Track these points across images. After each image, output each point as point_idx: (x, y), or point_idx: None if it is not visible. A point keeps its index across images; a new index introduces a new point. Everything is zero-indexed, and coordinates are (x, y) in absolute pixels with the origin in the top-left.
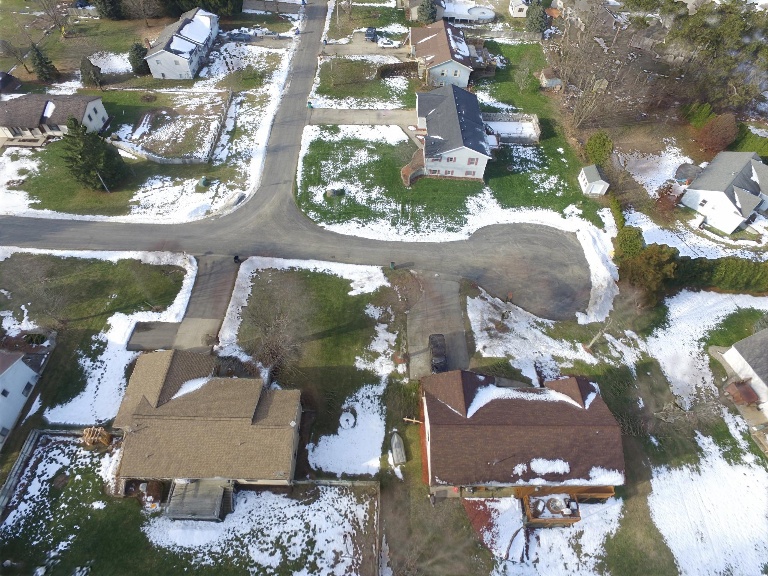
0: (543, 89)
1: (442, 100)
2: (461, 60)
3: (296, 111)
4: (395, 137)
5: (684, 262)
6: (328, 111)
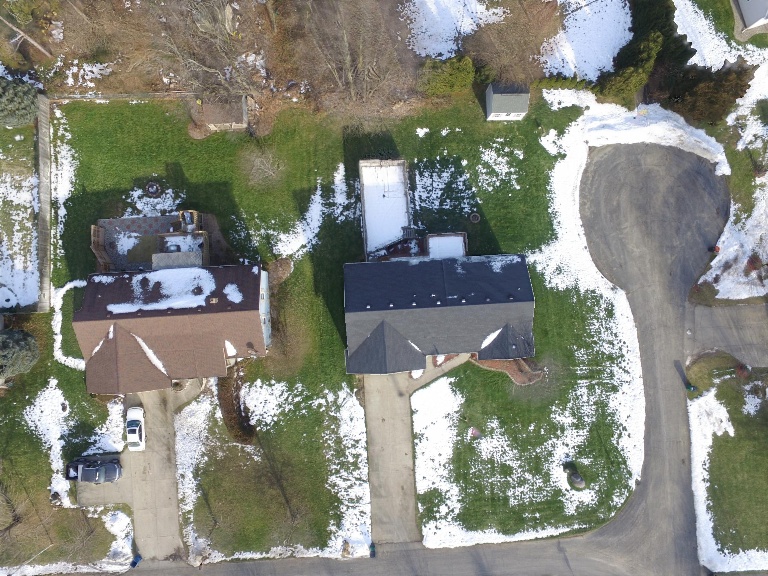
0: (253, 130)
1: (392, 330)
2: (243, 289)
3: (387, 571)
4: (444, 399)
5: (675, 31)
6: (379, 517)
